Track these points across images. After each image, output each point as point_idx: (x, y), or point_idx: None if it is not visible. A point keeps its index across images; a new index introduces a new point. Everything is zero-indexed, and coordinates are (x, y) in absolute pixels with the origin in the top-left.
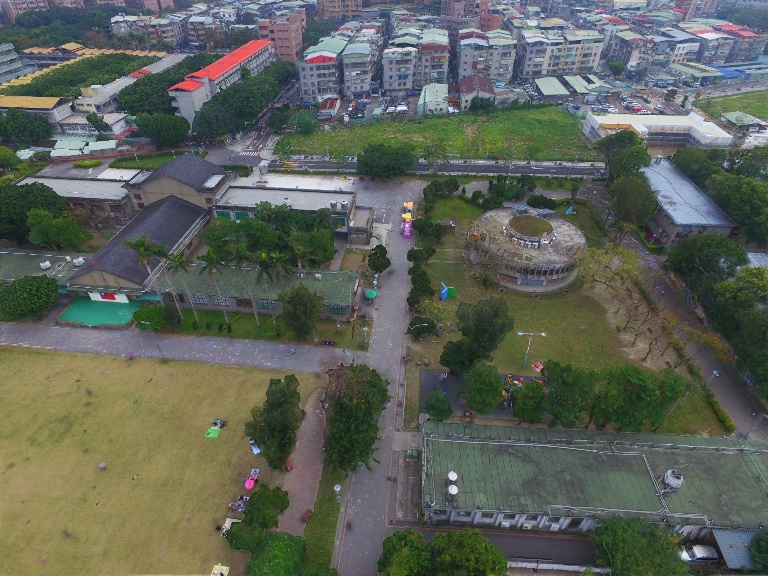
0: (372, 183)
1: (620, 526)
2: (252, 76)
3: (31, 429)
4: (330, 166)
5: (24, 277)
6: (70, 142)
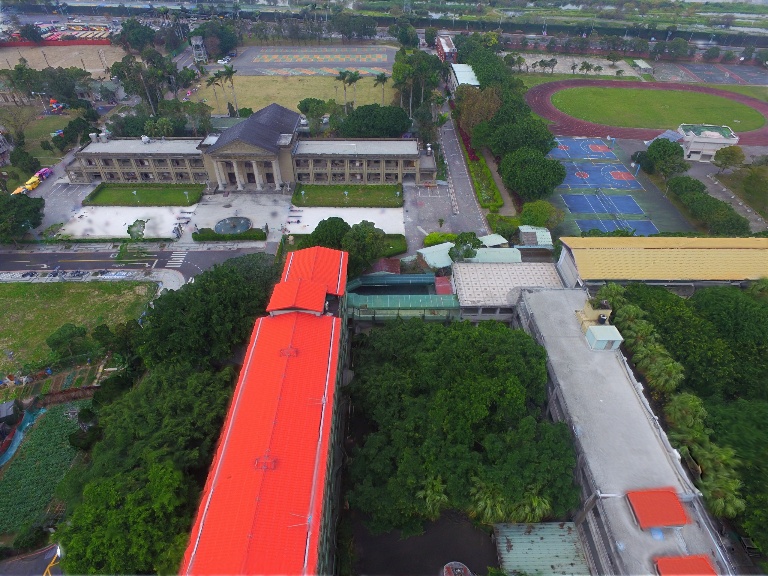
0: (33, 231)
1: (69, 72)
2: (154, 508)
3: (279, 98)
4: (74, 258)
5: (317, 103)
6: (497, 251)
